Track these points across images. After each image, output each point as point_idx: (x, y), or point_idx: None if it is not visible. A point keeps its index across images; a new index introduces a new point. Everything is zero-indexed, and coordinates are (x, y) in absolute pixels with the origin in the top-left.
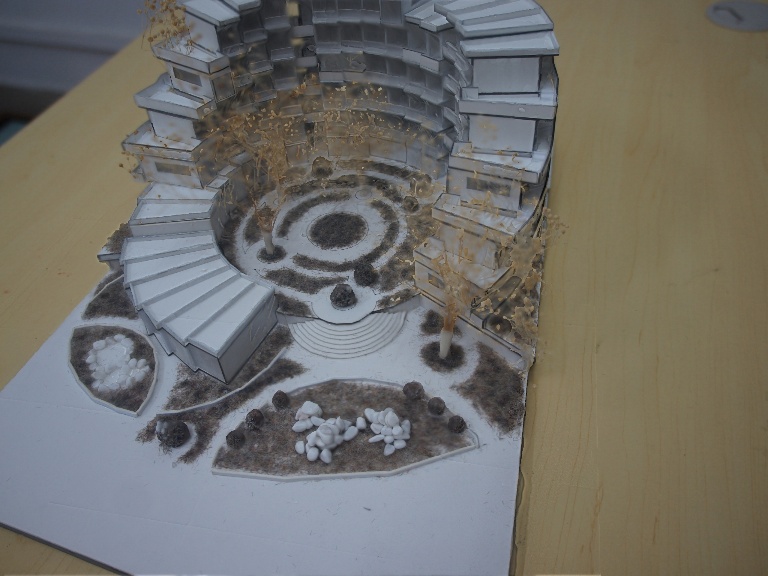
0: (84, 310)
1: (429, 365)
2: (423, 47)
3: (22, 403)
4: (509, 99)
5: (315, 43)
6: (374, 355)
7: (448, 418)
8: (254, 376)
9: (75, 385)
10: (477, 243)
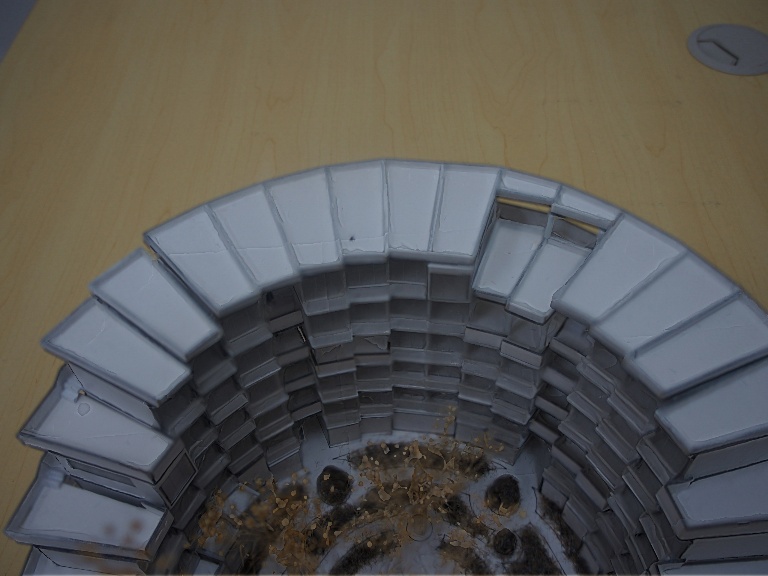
0: None
1: None
2: (488, 307)
3: None
4: (735, 475)
5: (306, 331)
6: None
7: None
8: None
9: None
10: None
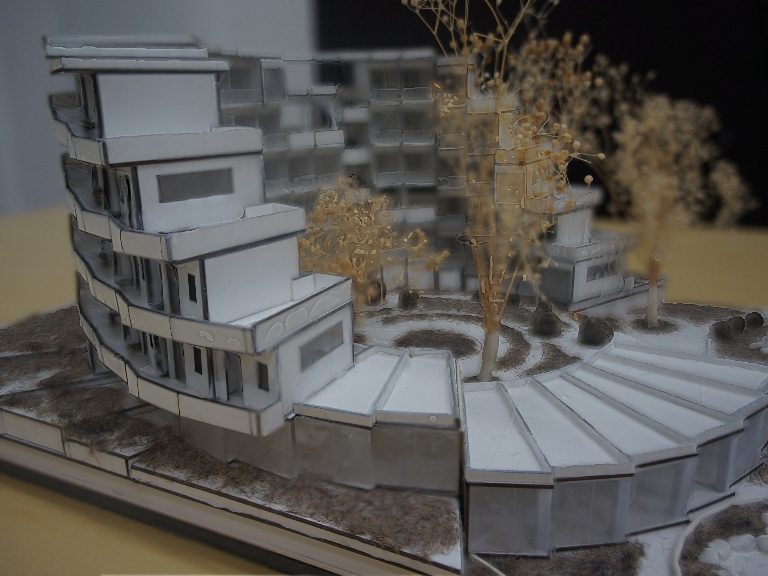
0: None
1: (671, 331)
2: None
3: None
4: None
5: None
6: None
7: None
8: None
9: None
10: (581, 219)
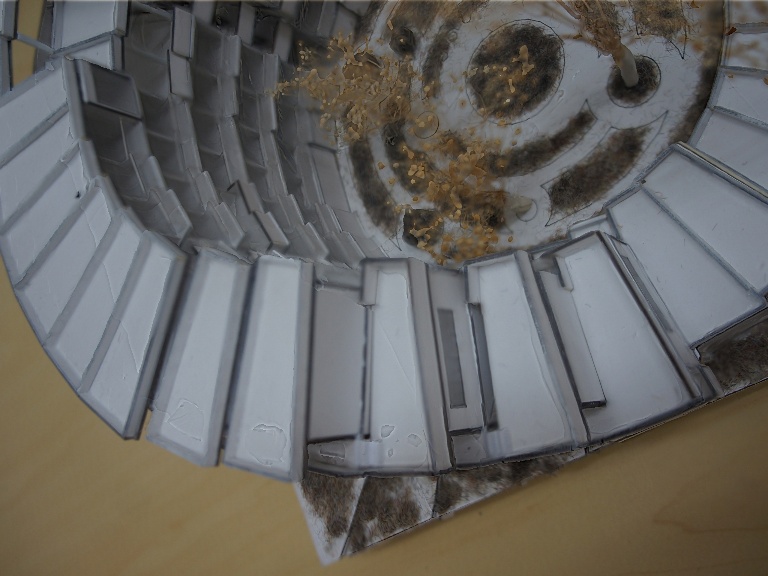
0: None
1: None
2: None
3: None
4: None
5: None
6: None
7: None
8: None
9: None
10: None
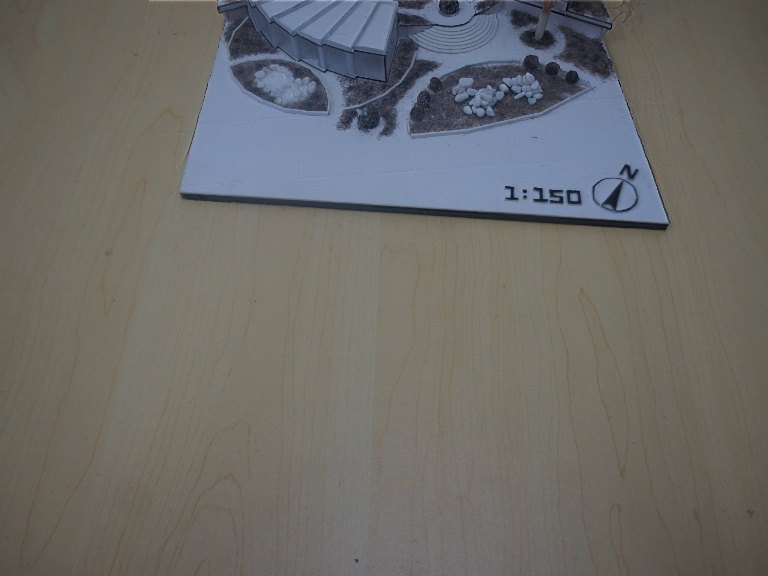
0: (228, 52)
1: (531, 46)
2: None
3: (224, 124)
4: None
5: None
6: (486, 46)
7: (562, 76)
8: (404, 73)
9: (260, 105)
10: None
